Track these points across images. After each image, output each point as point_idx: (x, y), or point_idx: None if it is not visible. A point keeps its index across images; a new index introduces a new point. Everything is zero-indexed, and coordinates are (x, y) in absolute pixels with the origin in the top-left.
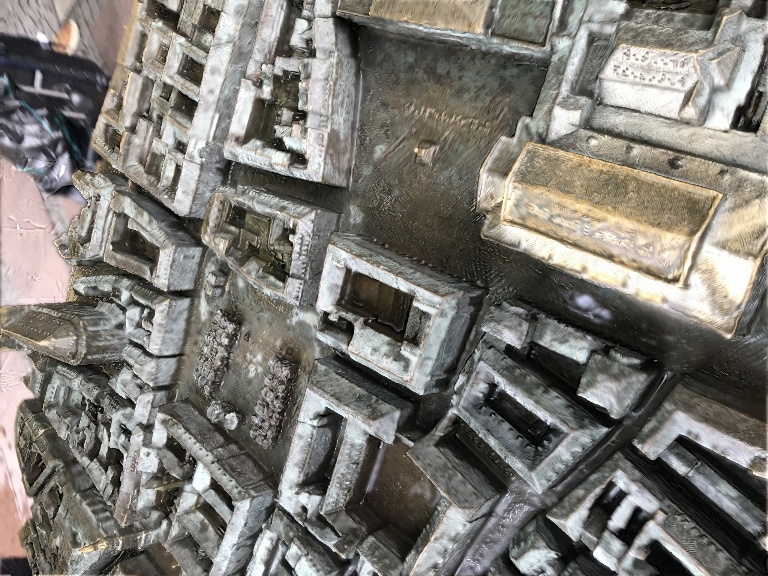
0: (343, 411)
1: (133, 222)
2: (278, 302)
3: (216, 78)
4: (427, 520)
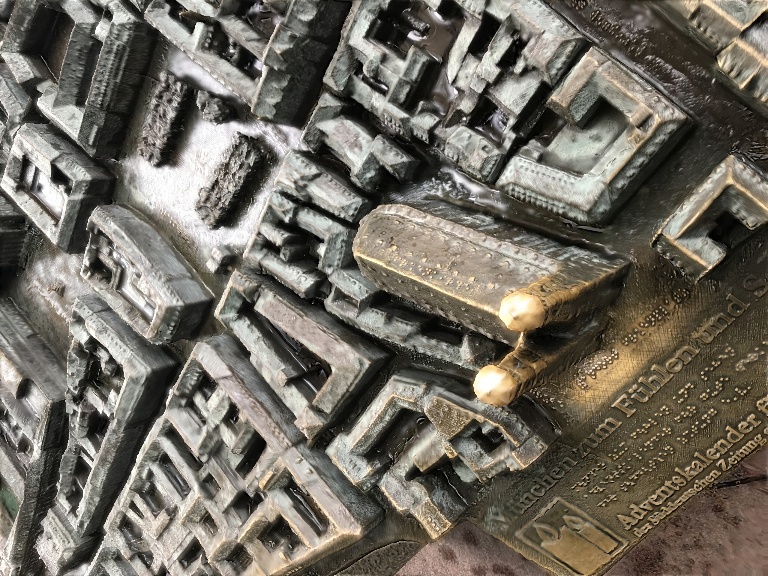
0: (59, 113)
1: (276, 378)
2: (166, 220)
3: (146, 443)
4: (64, 27)
